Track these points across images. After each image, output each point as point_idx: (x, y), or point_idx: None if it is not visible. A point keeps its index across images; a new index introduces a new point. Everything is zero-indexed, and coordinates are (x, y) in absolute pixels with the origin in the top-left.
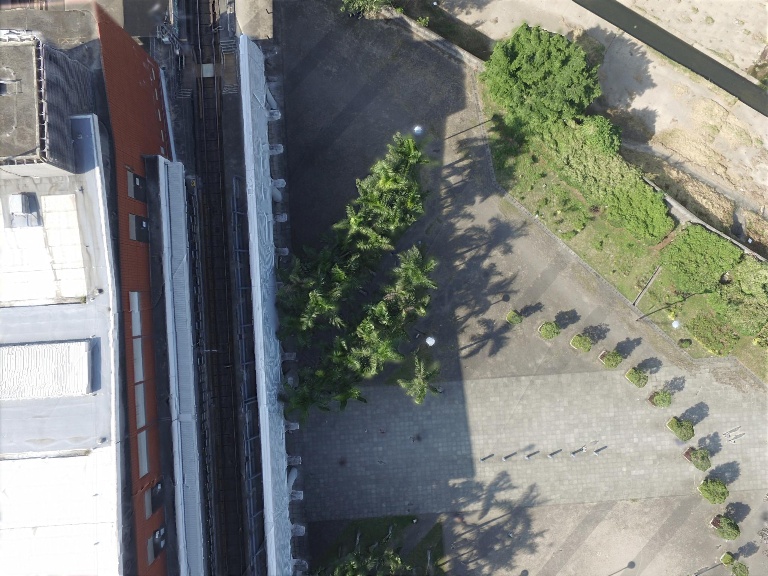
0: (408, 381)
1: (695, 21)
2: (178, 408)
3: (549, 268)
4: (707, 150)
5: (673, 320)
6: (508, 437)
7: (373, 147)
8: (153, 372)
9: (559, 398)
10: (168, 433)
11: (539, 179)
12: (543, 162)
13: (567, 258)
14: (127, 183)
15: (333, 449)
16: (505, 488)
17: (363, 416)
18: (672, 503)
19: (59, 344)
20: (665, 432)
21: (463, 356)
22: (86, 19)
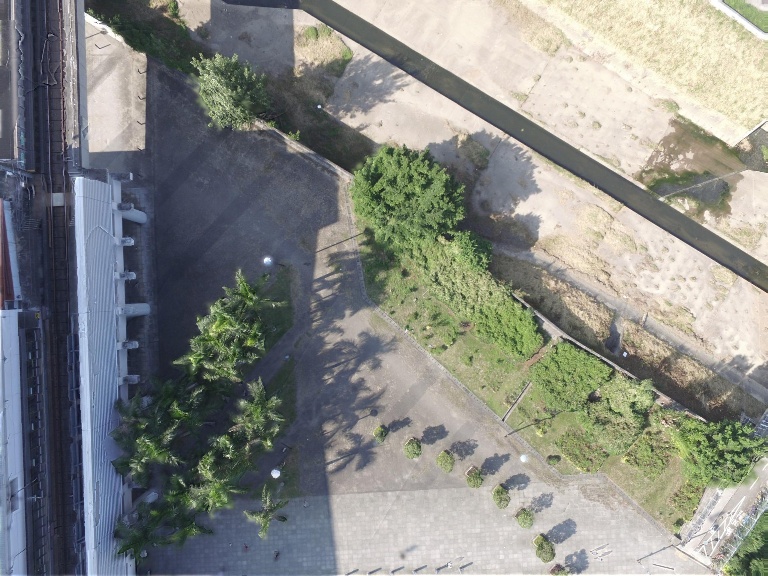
0: (251, 514)
1: (582, 126)
2: None
3: (418, 383)
4: (590, 257)
5: (542, 436)
6: (373, 552)
7: (243, 260)
8: None
9: (425, 514)
10: None
11: (410, 293)
12: (414, 276)
13: (436, 373)
14: None
15: (197, 562)
16: None
17: (228, 530)
18: None
19: None
20: (532, 549)
21: (329, 471)
22: None
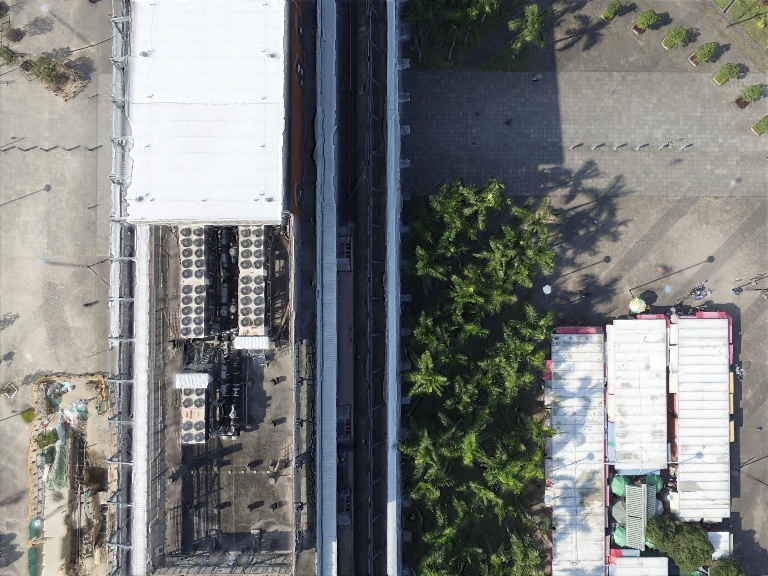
0: None
1: None
2: None
3: None
4: None
5: (762, 29)
6: (598, 128)
7: None
8: None
9: (649, 95)
10: None
11: None
12: None
13: None
14: None
15: (429, 128)
16: (592, 177)
17: (459, 98)
18: (753, 203)
19: None
20: (749, 135)
21: (558, 48)
22: None
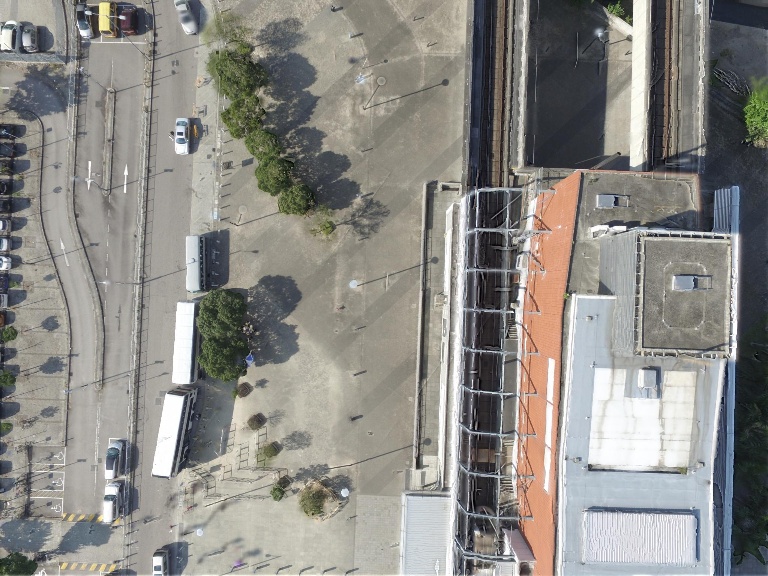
0: None
1: None
2: None
3: None
4: None
5: None
6: None
7: (754, 274)
8: None
9: None
10: None
11: None
12: None
13: None
14: None
15: None
16: None
17: None
18: None
19: (669, 515)
20: None
21: None
22: (682, 190)
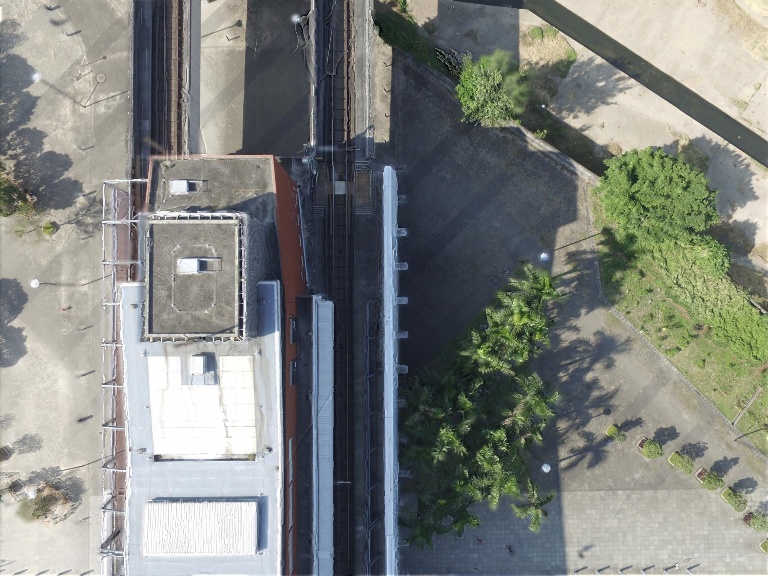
0: (523, 507)
1: None
2: (317, 545)
3: (651, 384)
4: None
5: None
6: (602, 550)
7: (483, 255)
8: (297, 510)
9: (655, 514)
10: (308, 571)
11: (645, 294)
12: (650, 277)
13: (669, 374)
14: (290, 332)
15: (429, 553)
16: None
17: None
18: None
19: (230, 503)
20: (758, 553)
21: (562, 467)
22: (261, 172)
